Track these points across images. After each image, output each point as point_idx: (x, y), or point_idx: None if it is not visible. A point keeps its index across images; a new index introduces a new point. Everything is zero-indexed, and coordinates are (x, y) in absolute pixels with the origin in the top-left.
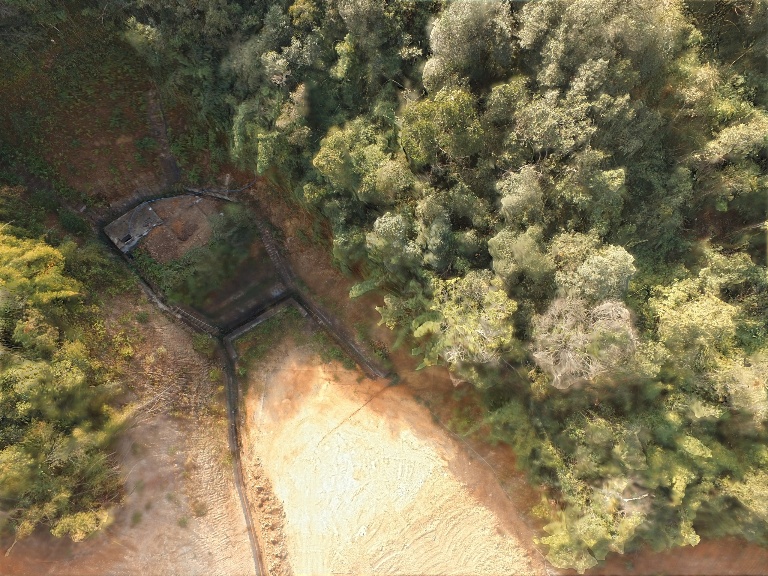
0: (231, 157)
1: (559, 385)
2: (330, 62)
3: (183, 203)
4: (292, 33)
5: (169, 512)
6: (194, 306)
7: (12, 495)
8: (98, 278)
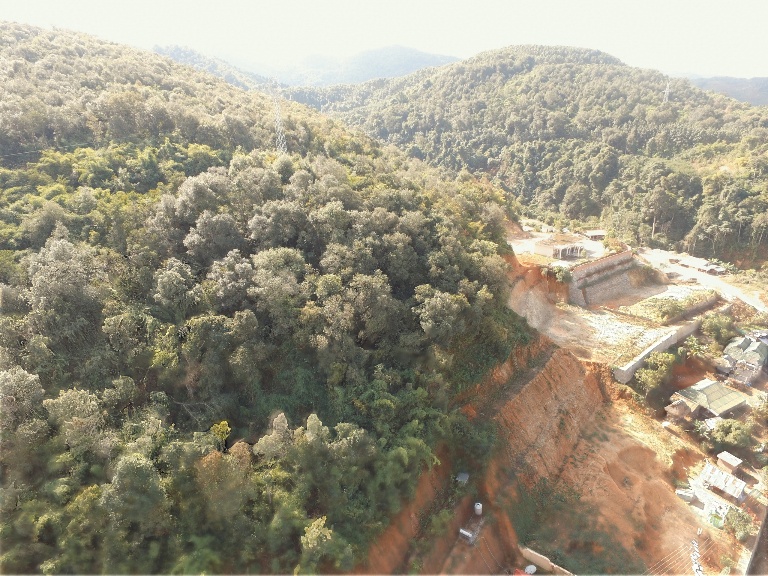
0: None
1: None
2: None
3: None
4: None
5: None
6: None
7: None
8: None
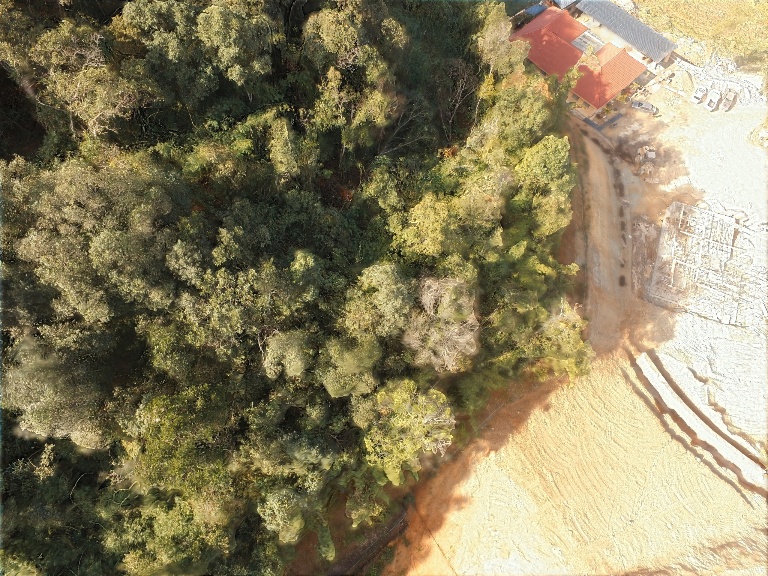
0: None
1: None
2: None
3: None
4: None
5: None
6: None
7: None
8: None
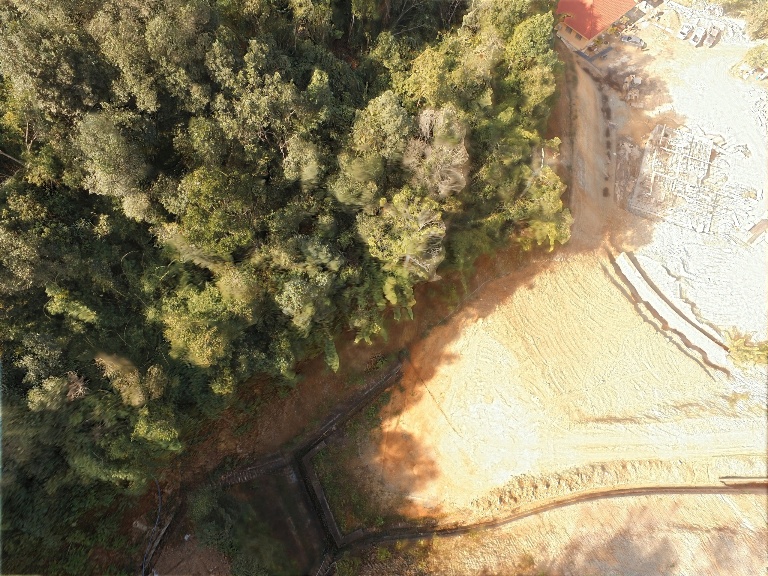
0: (118, 510)
1: (462, 185)
2: (61, 330)
3: None
4: (8, 363)
5: None
6: None
7: None
8: None
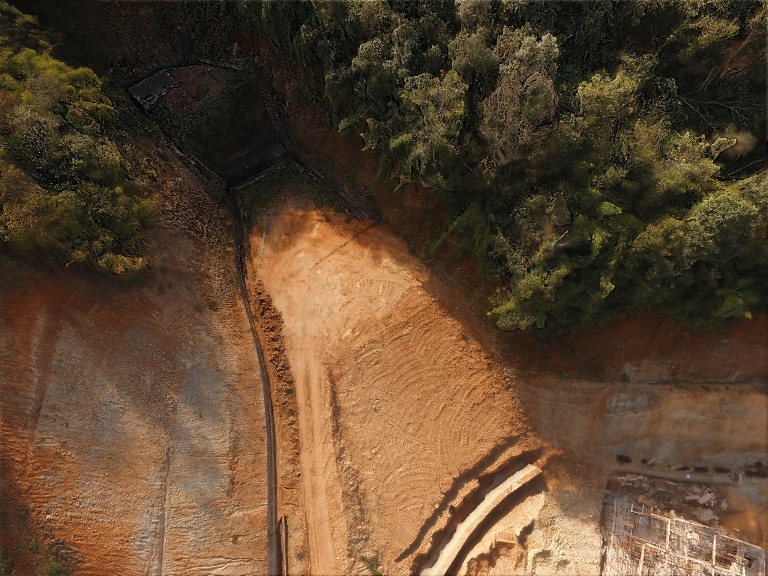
0: (239, 23)
1: (503, 160)
2: None
3: (196, 70)
4: None
5: (187, 297)
6: (206, 156)
7: (68, 232)
8: (126, 117)
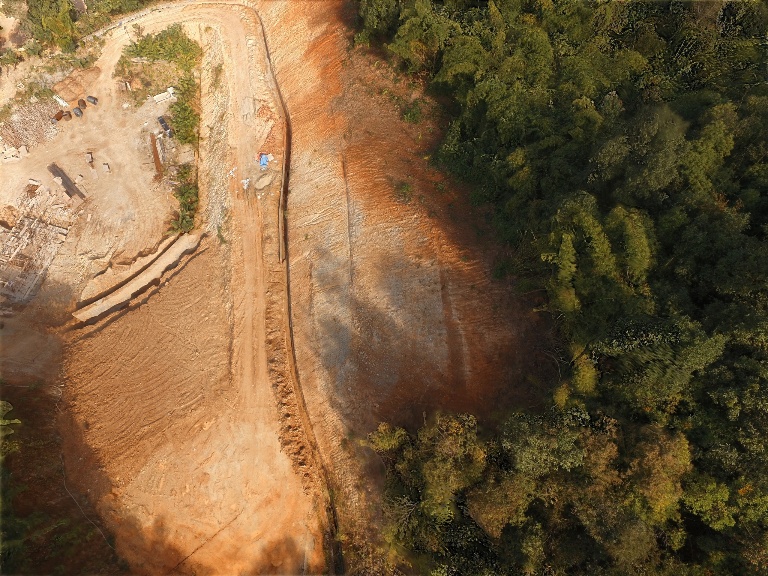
0: None
1: None
2: None
3: None
4: None
5: None
6: None
7: None
8: None
